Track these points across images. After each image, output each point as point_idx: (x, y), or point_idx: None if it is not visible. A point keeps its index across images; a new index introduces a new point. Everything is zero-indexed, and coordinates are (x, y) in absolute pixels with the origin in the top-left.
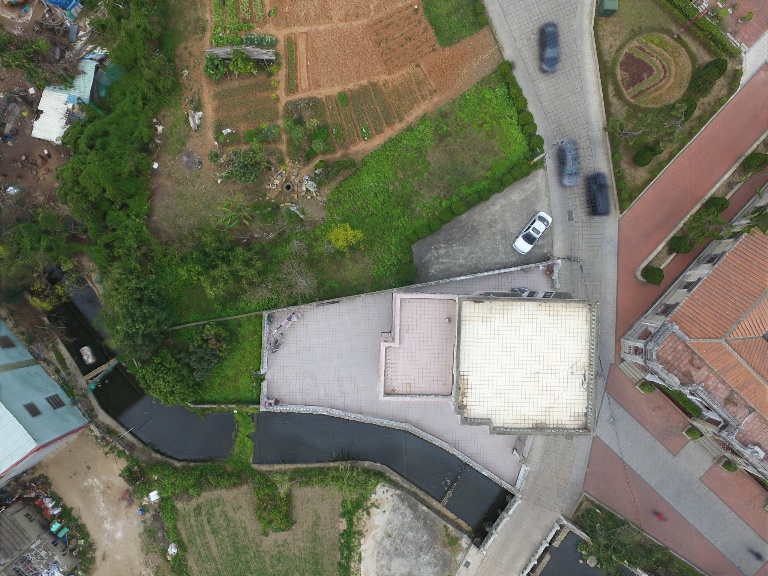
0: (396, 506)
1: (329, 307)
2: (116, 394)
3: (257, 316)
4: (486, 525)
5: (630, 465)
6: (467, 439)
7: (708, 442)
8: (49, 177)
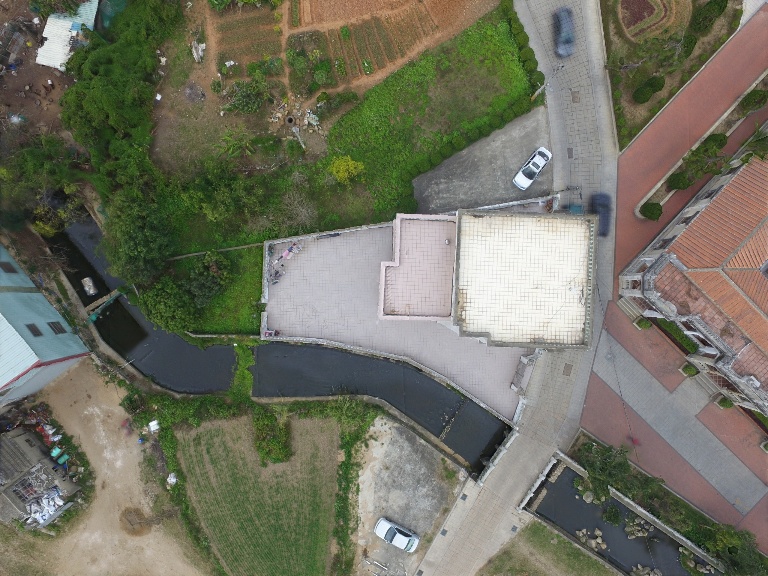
0: (394, 439)
1: (330, 240)
2: (117, 326)
3: (258, 247)
4: (483, 460)
5: (627, 401)
6: (465, 373)
7: (704, 379)
8: (53, 108)
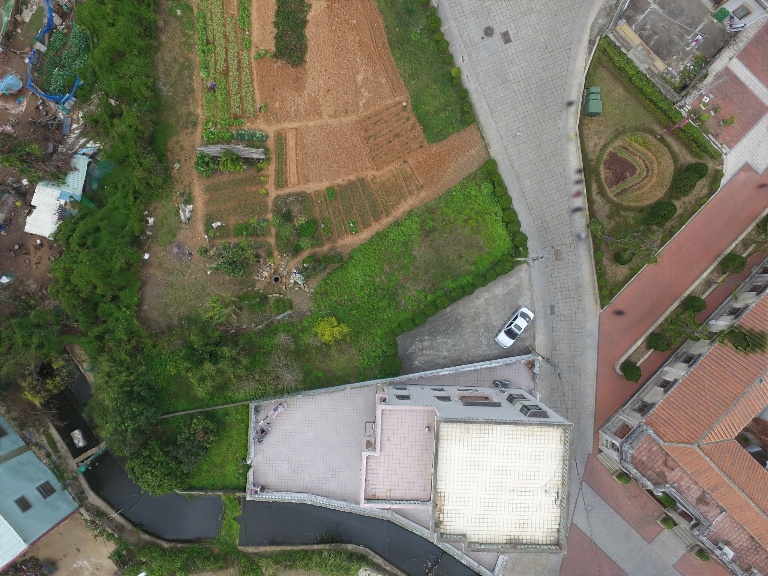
0: None
1: (315, 397)
2: (106, 476)
3: (244, 406)
4: None
5: (606, 552)
6: None
7: (682, 531)
8: (42, 266)
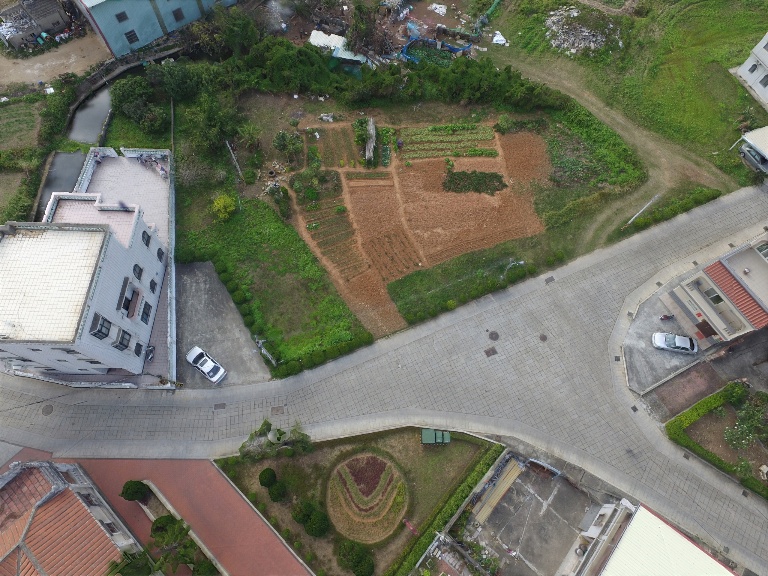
0: None
1: None
2: None
3: None
4: None
5: None
6: None
7: None
8: None
